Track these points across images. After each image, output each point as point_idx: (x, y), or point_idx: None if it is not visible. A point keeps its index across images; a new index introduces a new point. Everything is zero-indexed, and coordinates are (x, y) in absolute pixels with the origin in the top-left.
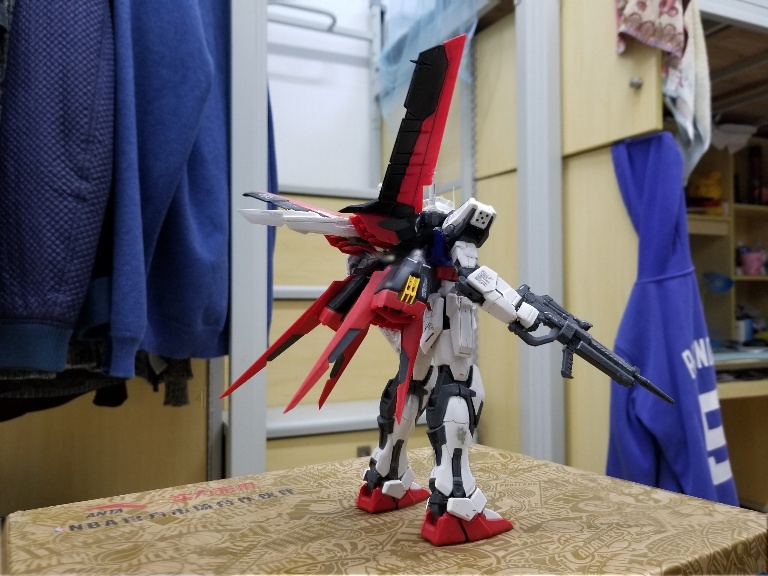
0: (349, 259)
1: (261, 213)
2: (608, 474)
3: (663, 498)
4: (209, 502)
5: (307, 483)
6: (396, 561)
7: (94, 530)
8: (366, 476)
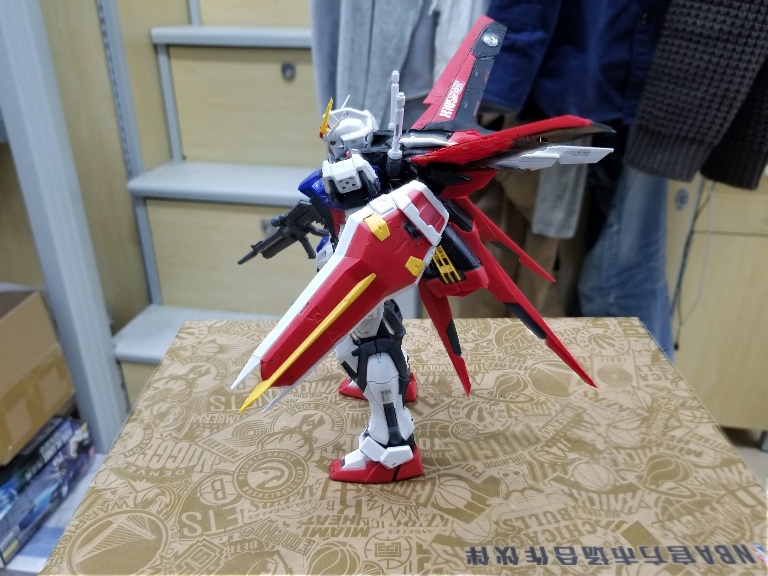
0: (445, 210)
1: (585, 153)
2: (122, 421)
3: (187, 367)
4: (587, 567)
5: (438, 574)
6: (457, 382)
7: (716, 536)
8: (411, 450)
